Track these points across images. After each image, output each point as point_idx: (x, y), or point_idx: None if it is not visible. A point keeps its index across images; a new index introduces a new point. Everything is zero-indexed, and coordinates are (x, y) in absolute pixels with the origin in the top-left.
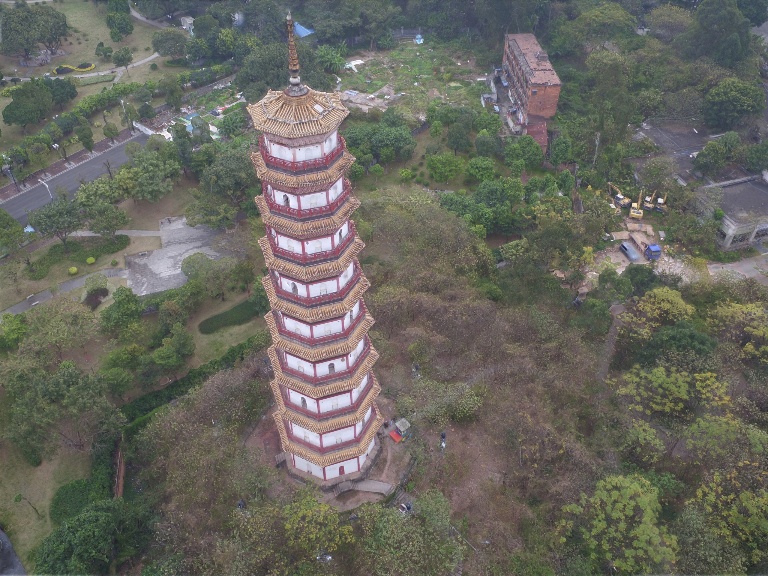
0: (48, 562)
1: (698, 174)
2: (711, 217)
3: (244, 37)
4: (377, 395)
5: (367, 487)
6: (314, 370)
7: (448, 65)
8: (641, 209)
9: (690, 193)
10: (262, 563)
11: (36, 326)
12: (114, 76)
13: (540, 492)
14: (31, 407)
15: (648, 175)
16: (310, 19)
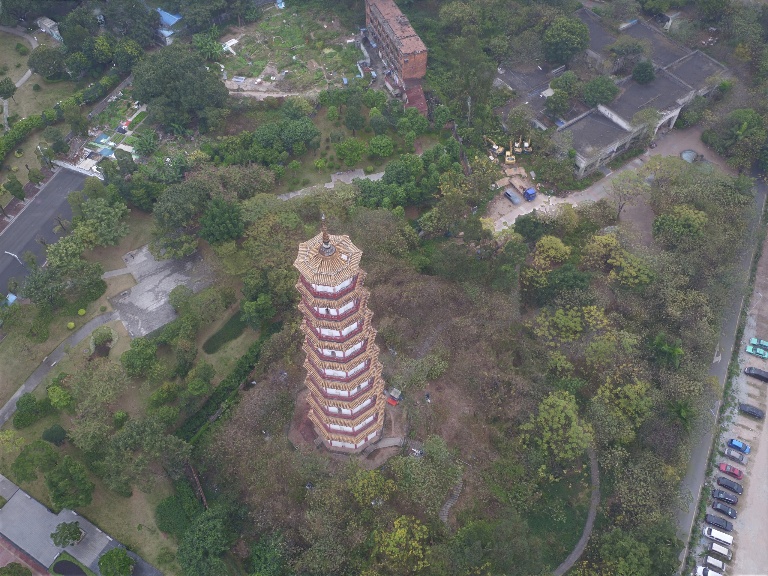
0: (193, 564)
1: (550, 115)
2: (567, 158)
3: (120, 43)
4: (383, 387)
5: (385, 444)
6: (348, 393)
7: (316, 30)
8: (513, 154)
9: (549, 140)
10: (342, 520)
11: (80, 391)
12: (1, 107)
13: (497, 411)
14: (120, 460)
15: (513, 124)
16: (173, 5)
